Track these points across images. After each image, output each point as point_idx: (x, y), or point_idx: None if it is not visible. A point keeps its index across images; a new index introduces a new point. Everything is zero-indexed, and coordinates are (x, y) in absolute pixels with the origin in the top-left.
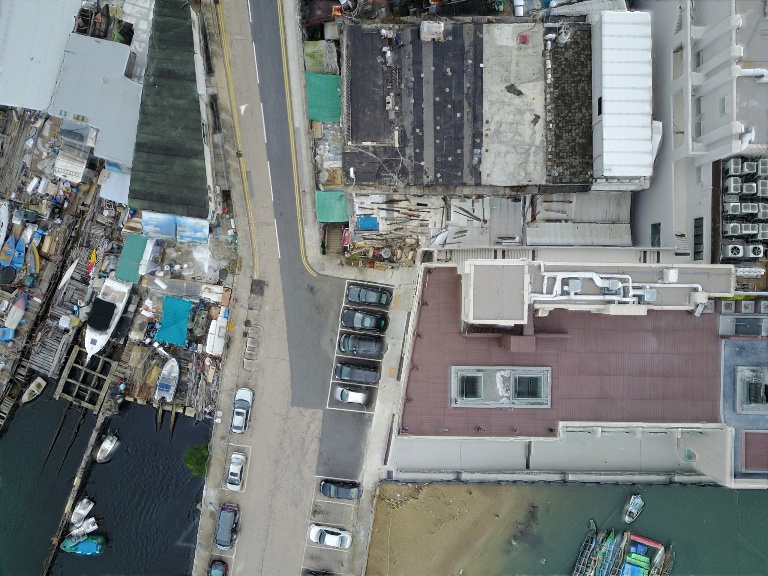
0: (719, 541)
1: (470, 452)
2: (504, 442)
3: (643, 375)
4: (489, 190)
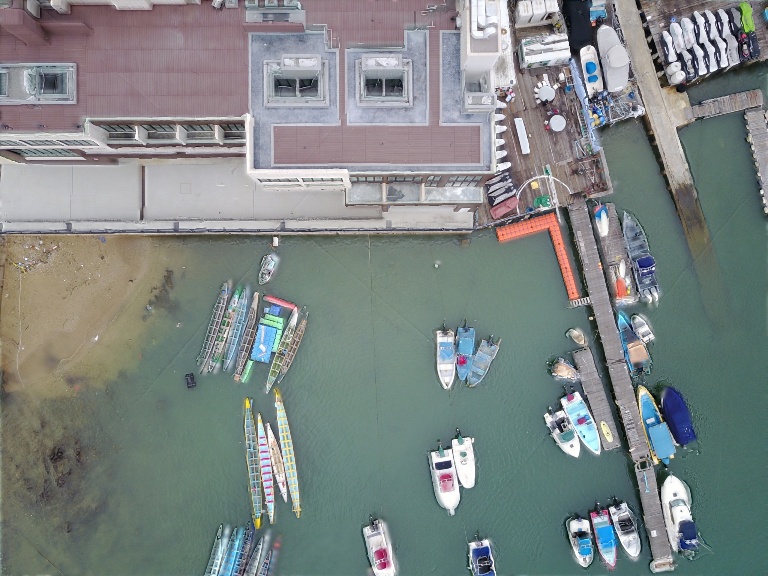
0: (354, 301)
1: (80, 203)
2: (116, 194)
3: (170, 71)
4: None
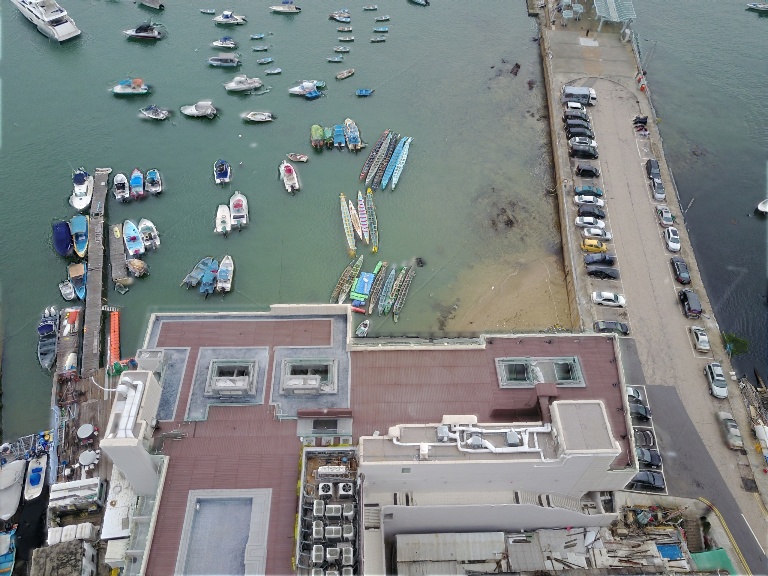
0: None
1: None
2: None
3: (419, 385)
4: (573, 573)
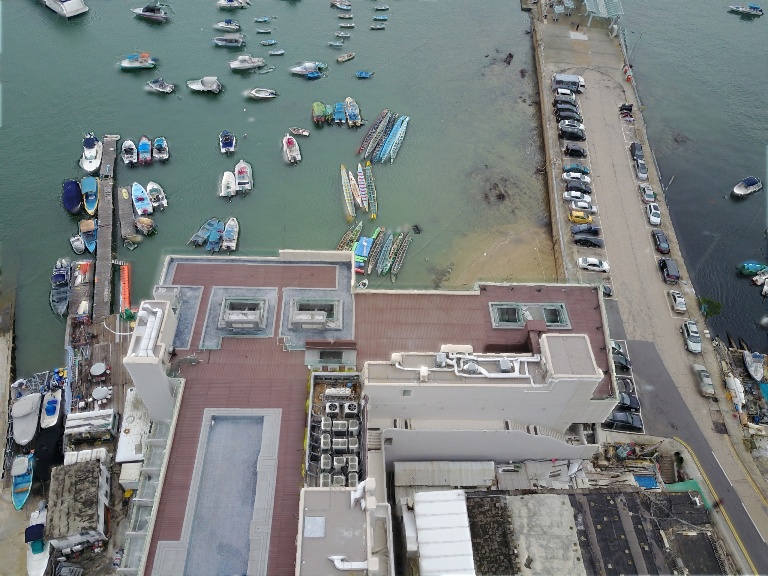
0: None
1: None
2: None
3: (418, 324)
4: (557, 492)
